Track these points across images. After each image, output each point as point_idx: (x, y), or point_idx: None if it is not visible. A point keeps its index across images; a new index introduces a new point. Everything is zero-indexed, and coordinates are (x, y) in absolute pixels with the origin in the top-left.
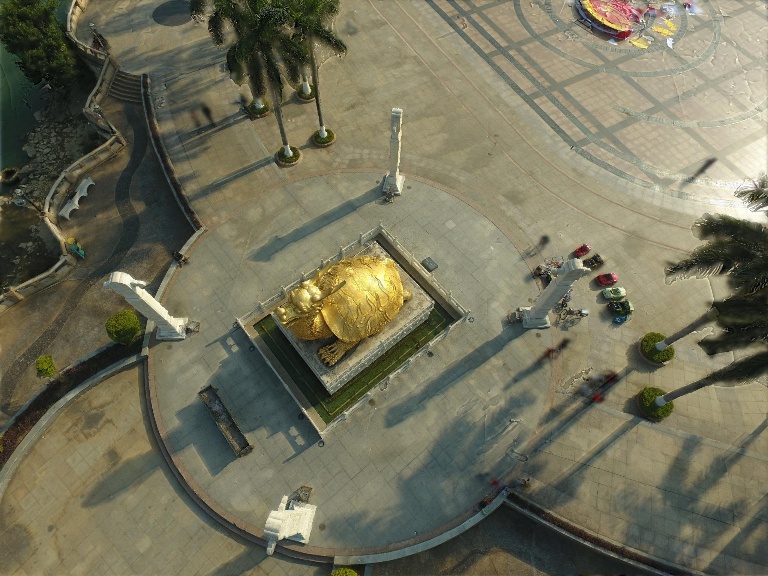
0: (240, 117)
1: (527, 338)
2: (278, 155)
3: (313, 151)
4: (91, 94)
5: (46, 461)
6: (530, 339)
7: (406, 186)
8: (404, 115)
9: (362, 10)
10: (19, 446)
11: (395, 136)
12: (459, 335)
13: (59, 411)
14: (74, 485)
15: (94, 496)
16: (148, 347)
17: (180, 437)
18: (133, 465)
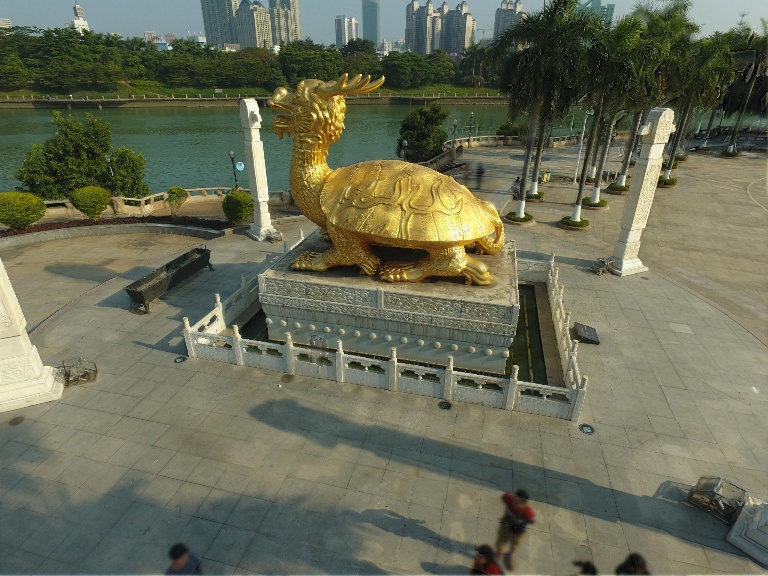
0: (506, 192)
1: (721, 566)
2: (508, 213)
3: (550, 227)
4: (419, 163)
5: (93, 242)
6: (730, 575)
7: (641, 275)
8: (711, 248)
9: (731, 195)
10: (102, 225)
11: (645, 154)
12: (532, 426)
13: (145, 229)
14: (70, 258)
15: (59, 268)
16: (233, 230)
17: (142, 273)
18: (101, 272)
